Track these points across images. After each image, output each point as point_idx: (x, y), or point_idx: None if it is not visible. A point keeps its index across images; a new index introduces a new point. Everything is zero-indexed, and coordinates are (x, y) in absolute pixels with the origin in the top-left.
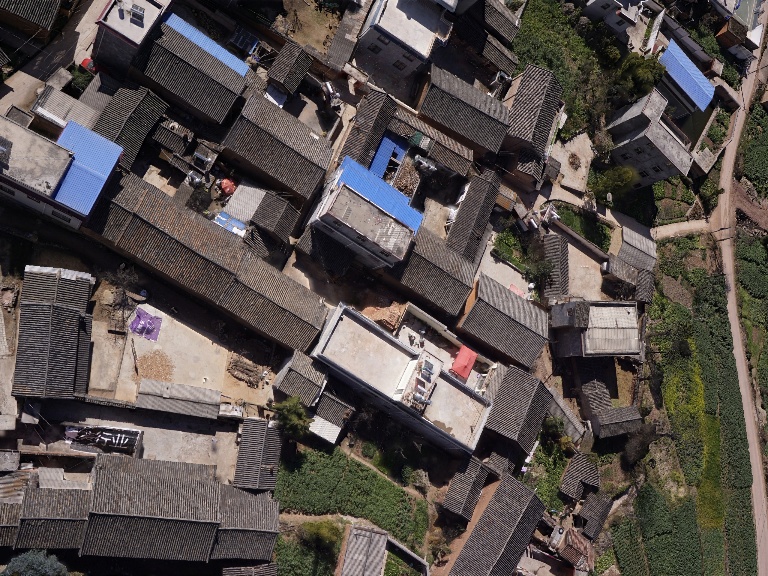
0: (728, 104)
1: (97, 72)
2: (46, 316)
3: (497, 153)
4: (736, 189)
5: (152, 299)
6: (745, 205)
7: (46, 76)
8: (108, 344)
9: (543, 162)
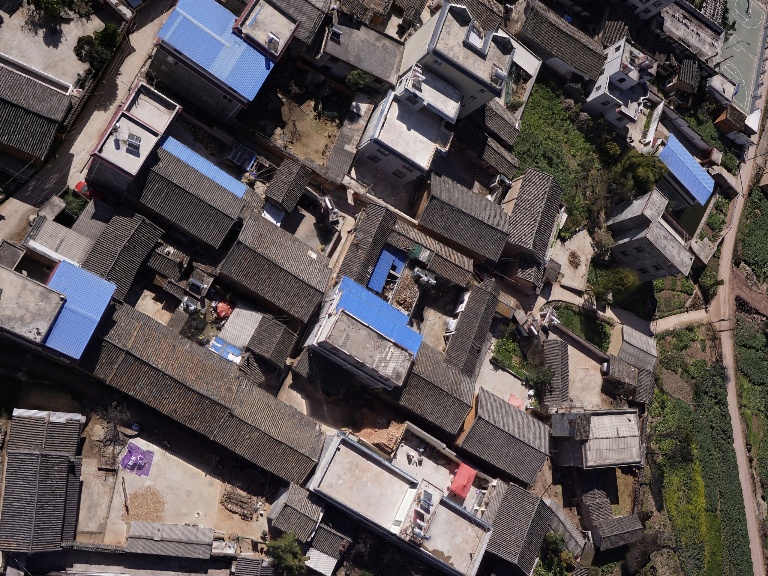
0: (727, 191)
1: (91, 196)
2: (34, 465)
3: (497, 261)
4: (735, 276)
5: (144, 432)
6: (744, 291)
7: (39, 202)
8: (98, 482)
9: (543, 267)
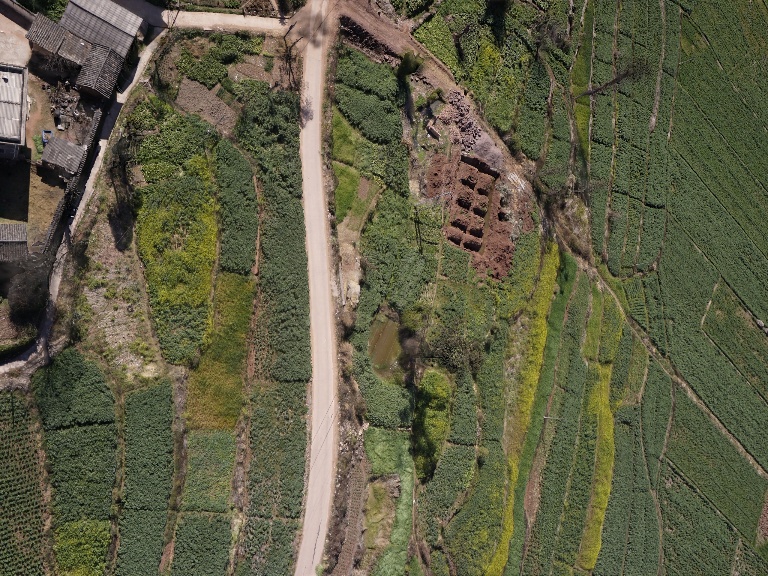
0: None
1: None
2: None
3: None
4: None
5: None
6: (363, 16)
7: None
8: None
9: None
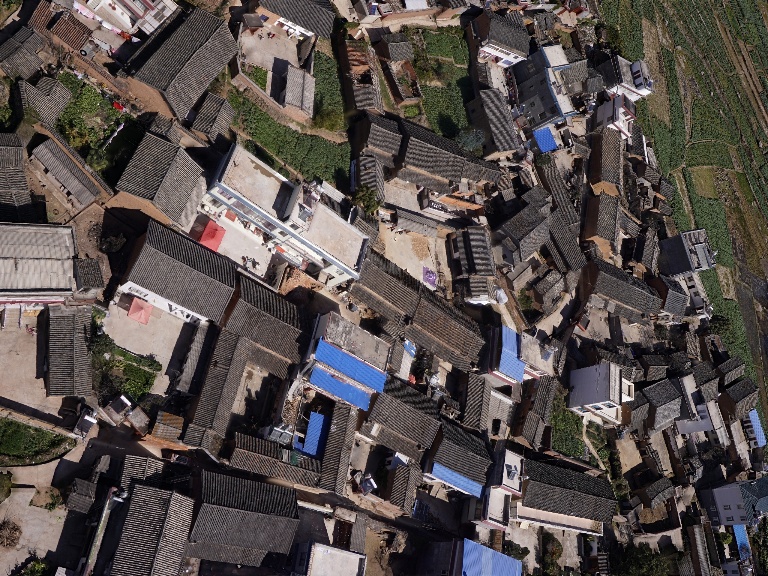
0: None
1: None
2: None
3: None
4: None
5: None
6: None
7: None
8: (442, 266)
9: (122, 486)
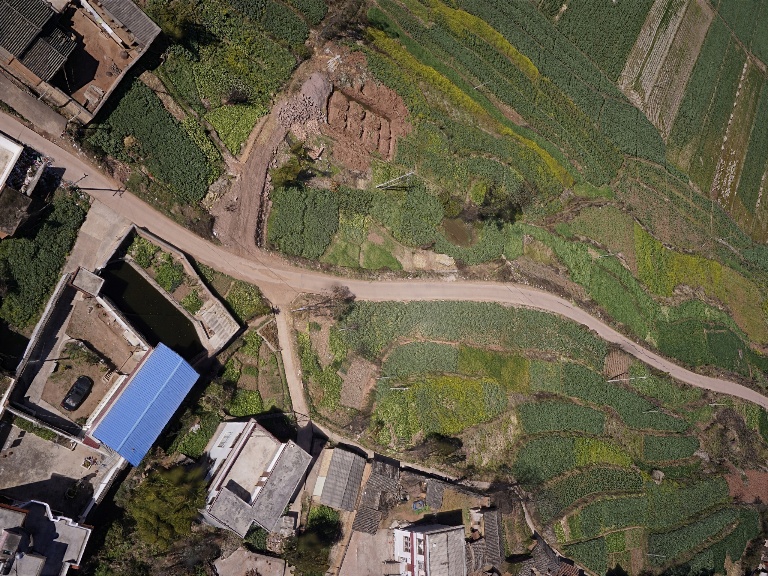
0: None
1: None
2: None
3: None
4: (232, 239)
5: None
6: (246, 220)
7: None
8: None
9: None
